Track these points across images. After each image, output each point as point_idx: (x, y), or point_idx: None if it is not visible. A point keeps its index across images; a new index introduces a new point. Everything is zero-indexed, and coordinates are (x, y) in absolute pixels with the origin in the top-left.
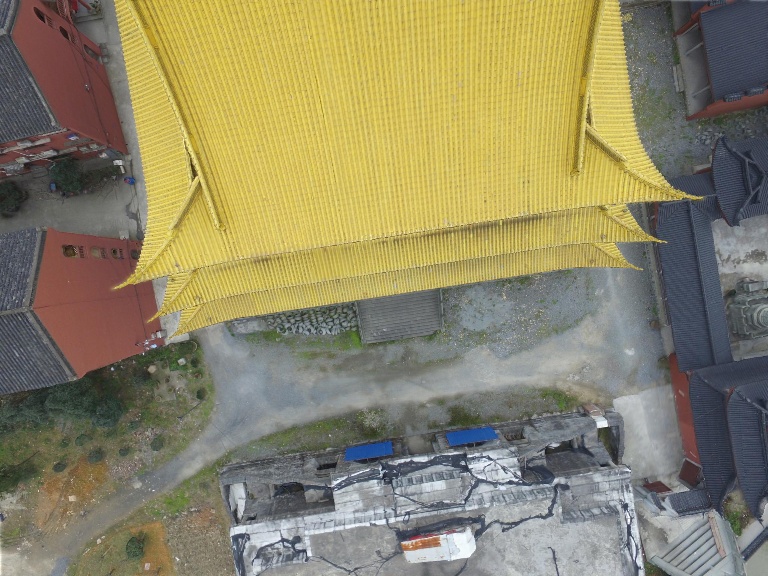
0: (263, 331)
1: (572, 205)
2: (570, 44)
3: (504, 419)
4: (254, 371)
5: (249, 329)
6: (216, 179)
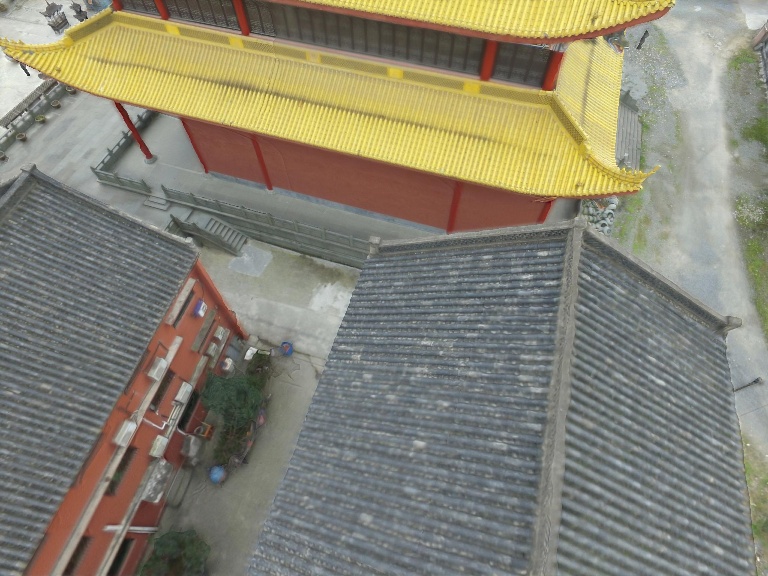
0: None
1: None
2: None
3: (763, 102)
4: None
5: None
6: None
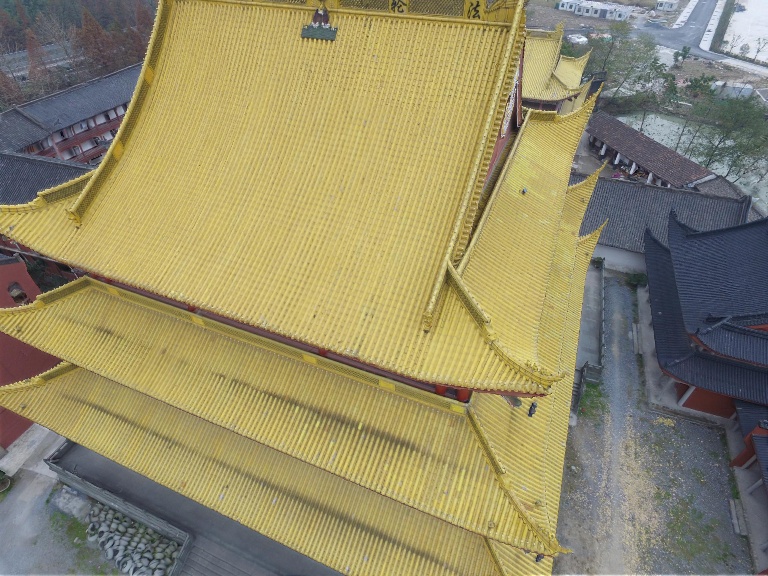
0: (77, 519)
1: (414, 371)
2: (453, 190)
3: None
4: (12, 565)
5: (68, 506)
6: (112, 188)
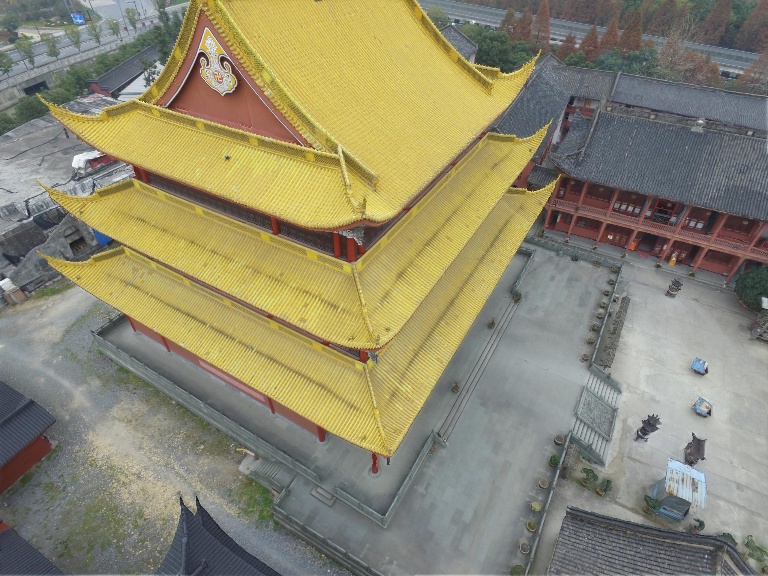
0: None
1: None
2: None
3: None
4: None
5: None
6: None
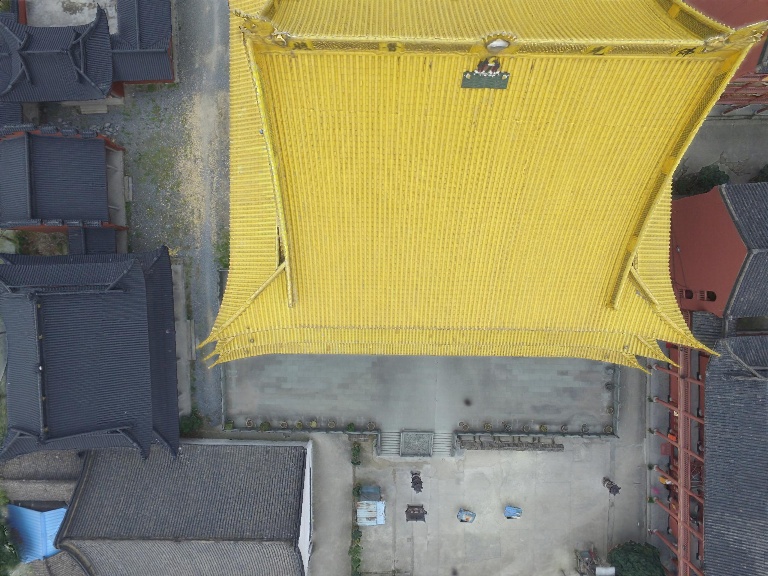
0: None
1: None
2: None
3: None
4: None
5: None
6: None
